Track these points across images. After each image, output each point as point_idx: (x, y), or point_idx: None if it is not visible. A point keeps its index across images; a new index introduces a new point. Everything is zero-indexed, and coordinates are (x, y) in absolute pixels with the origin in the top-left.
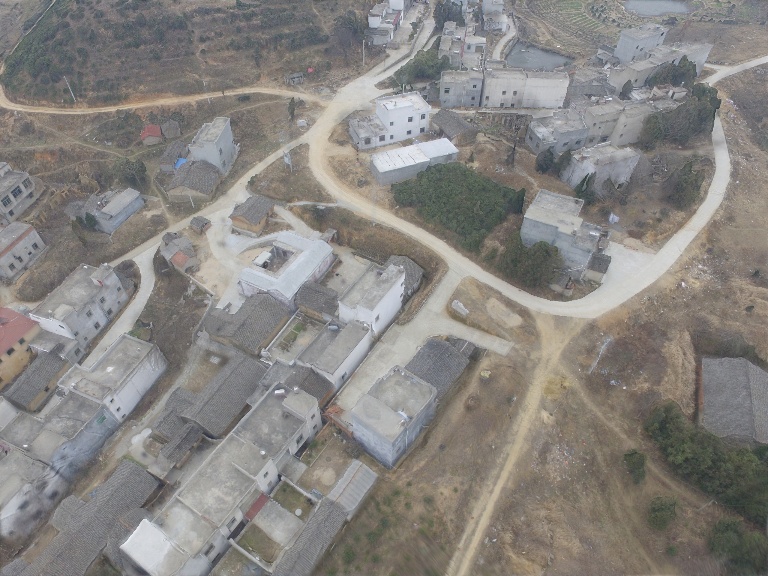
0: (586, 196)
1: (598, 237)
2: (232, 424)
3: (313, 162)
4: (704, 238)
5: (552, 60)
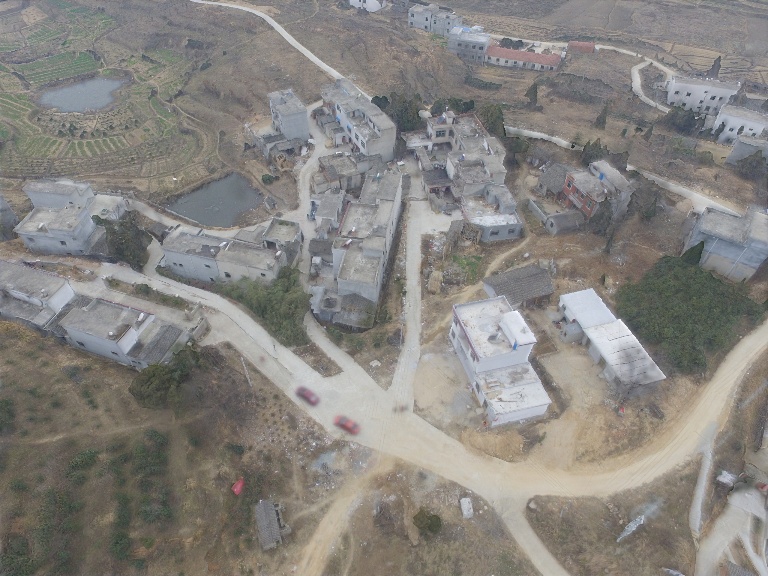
0: (641, 213)
1: None
2: None
3: (594, 489)
4: None
5: (227, 189)
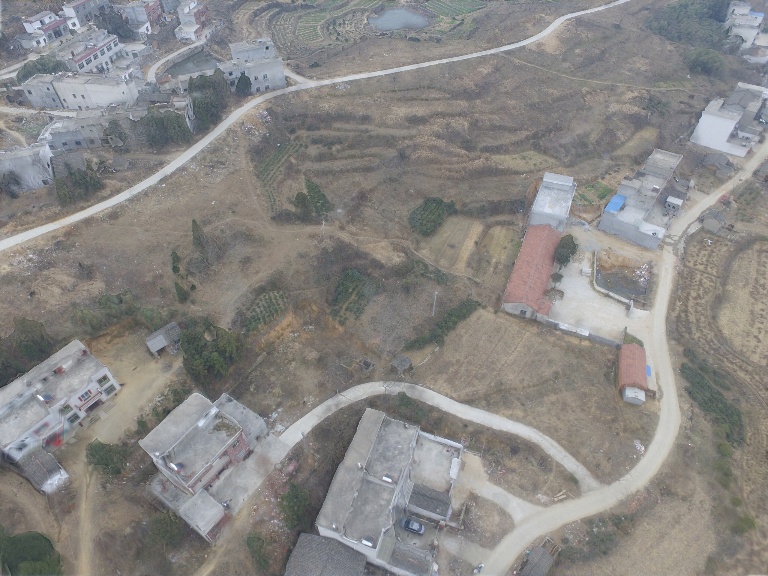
0: None
1: None
2: None
3: None
4: (62, 231)
5: None
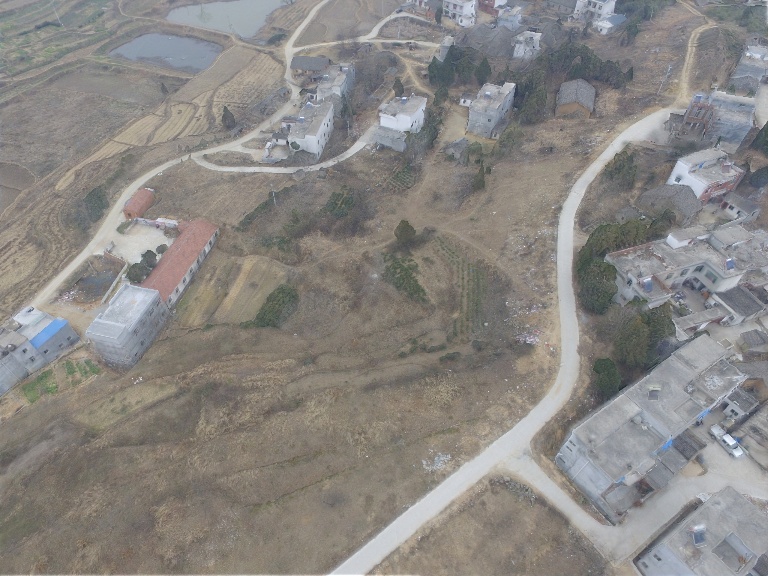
0: None
1: (694, 99)
2: None
3: None
4: None
5: None
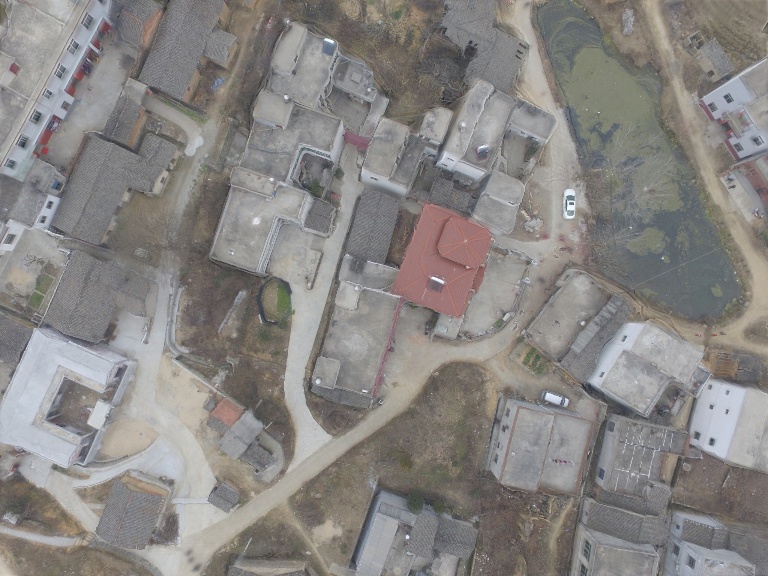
0: None
1: None
2: (80, 152)
3: None
4: None
5: None
